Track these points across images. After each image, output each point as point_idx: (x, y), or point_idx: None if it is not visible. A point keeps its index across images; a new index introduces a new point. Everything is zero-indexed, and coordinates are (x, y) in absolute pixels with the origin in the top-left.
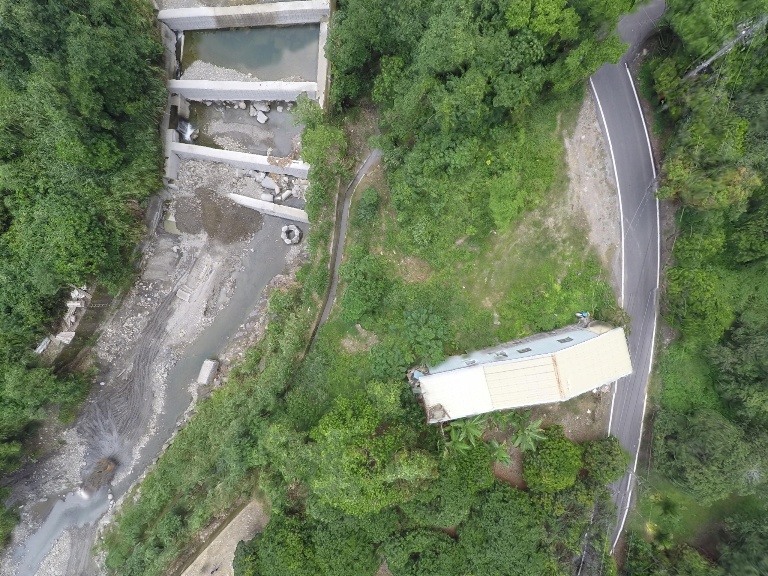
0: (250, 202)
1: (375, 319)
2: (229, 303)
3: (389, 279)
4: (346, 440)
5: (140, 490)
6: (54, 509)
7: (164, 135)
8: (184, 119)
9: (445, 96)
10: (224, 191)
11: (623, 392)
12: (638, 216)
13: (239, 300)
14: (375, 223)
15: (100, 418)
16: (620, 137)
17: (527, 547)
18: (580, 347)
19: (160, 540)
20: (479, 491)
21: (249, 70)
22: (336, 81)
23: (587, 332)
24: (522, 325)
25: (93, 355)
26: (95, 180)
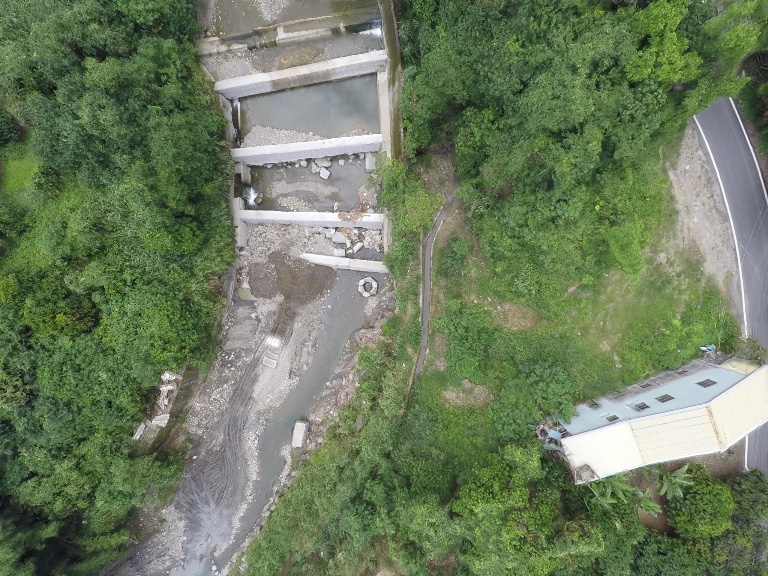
0: (324, 260)
1: (483, 372)
2: (312, 362)
3: (488, 327)
4: (500, 515)
5: (245, 559)
6: None
7: (231, 205)
8: (247, 185)
9: (562, 154)
10: (297, 252)
11: None
12: (753, 240)
13: (322, 358)
14: (464, 271)
15: (196, 491)
16: (726, 163)
17: None
18: (731, 393)
19: None
20: None
21: (309, 129)
22: (410, 134)
23: (726, 371)
24: (646, 366)
25: (184, 431)
26: (178, 264)
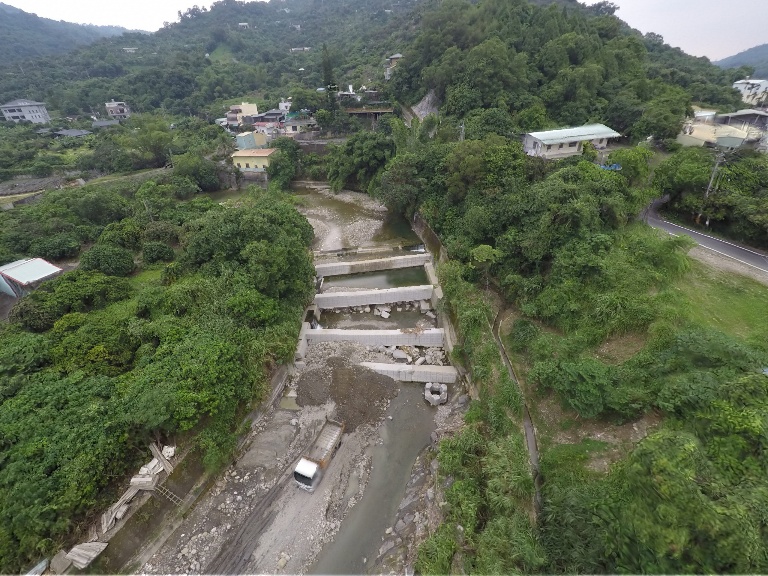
0: (385, 367)
1: None
2: (363, 494)
3: None
4: None
5: None
6: None
7: None
8: (316, 320)
9: None
10: (357, 360)
11: None
12: None
13: (378, 487)
14: None
15: None
16: (701, 242)
17: None
18: None
19: None
20: None
21: None
22: None
23: None
24: None
25: None
26: None
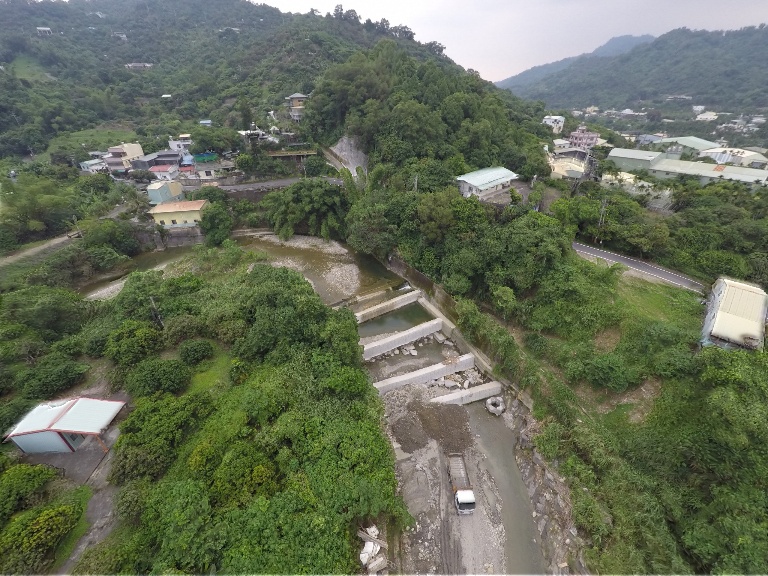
0: (450, 397)
1: None
2: (501, 498)
3: None
4: None
5: None
6: None
7: None
8: None
9: None
10: (426, 399)
11: None
12: (651, 270)
13: (506, 489)
14: (551, 345)
15: None
16: (604, 256)
17: None
18: (729, 283)
19: None
20: None
21: None
22: None
23: None
24: (694, 318)
25: None
26: None
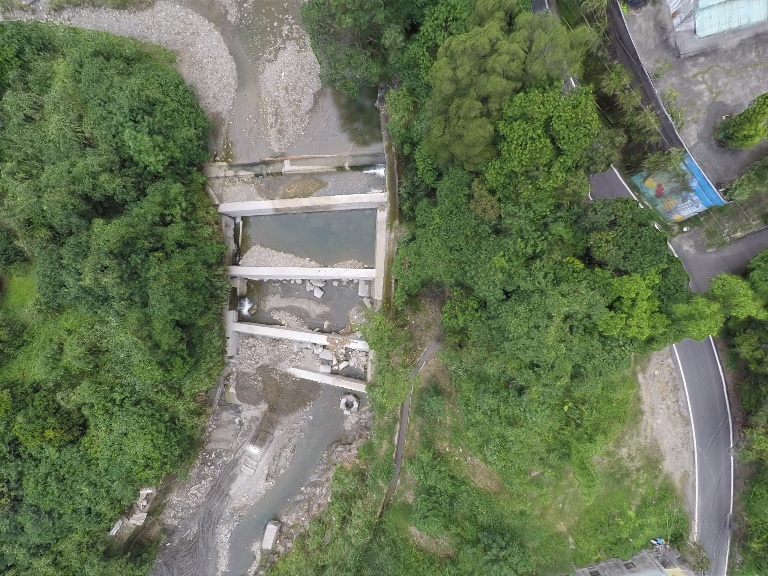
0: (309, 376)
1: (447, 525)
2: (289, 467)
3: (456, 477)
4: None
5: None
6: None
7: (225, 317)
8: (242, 297)
9: (533, 380)
10: (284, 367)
11: None
12: (712, 446)
13: (299, 464)
14: (440, 417)
15: (166, 575)
16: (694, 373)
17: None
18: None
19: None
20: None
21: (307, 254)
22: (400, 286)
23: None
24: (598, 551)
25: (160, 522)
26: (167, 385)
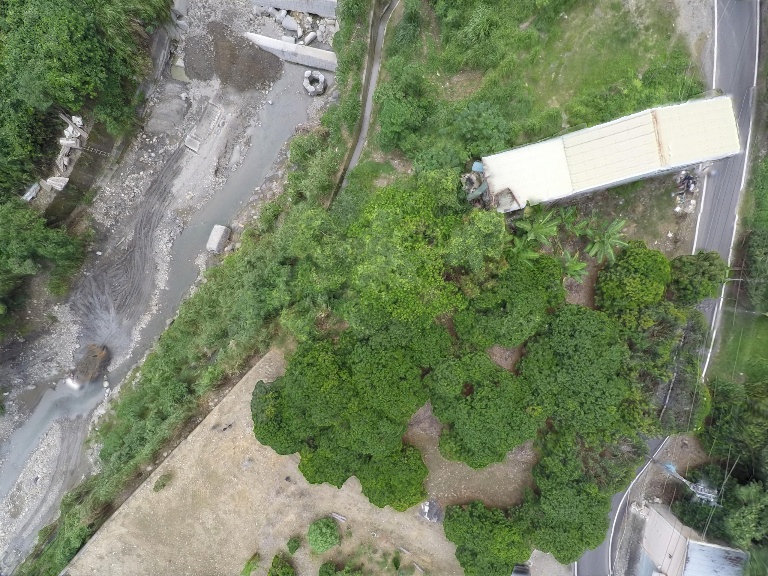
0: (269, 42)
1: None
2: (243, 163)
3: None
4: (396, 221)
5: (140, 374)
6: (43, 399)
7: None
8: None
9: None
10: (240, 28)
11: (710, 211)
12: None
13: (254, 160)
14: (415, 44)
15: (96, 294)
16: None
17: (607, 367)
18: (683, 108)
19: (163, 408)
20: (547, 308)
21: None
22: None
23: None
24: None
25: (89, 216)
26: None
